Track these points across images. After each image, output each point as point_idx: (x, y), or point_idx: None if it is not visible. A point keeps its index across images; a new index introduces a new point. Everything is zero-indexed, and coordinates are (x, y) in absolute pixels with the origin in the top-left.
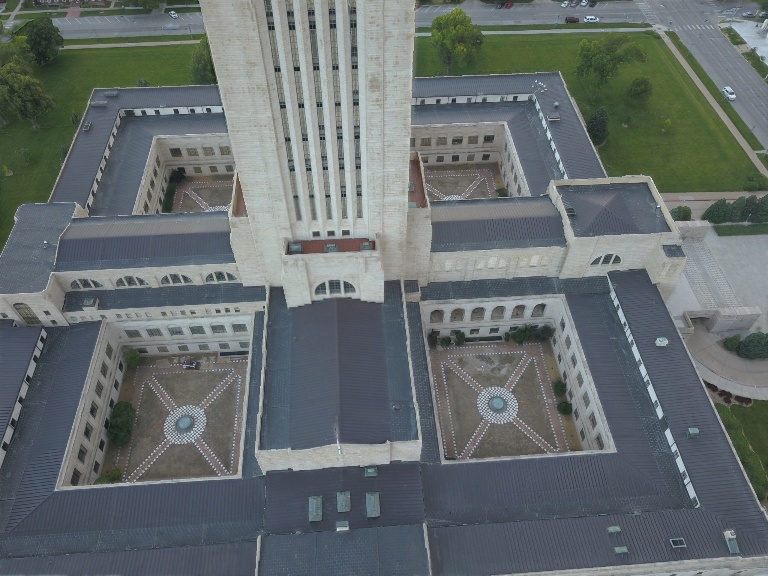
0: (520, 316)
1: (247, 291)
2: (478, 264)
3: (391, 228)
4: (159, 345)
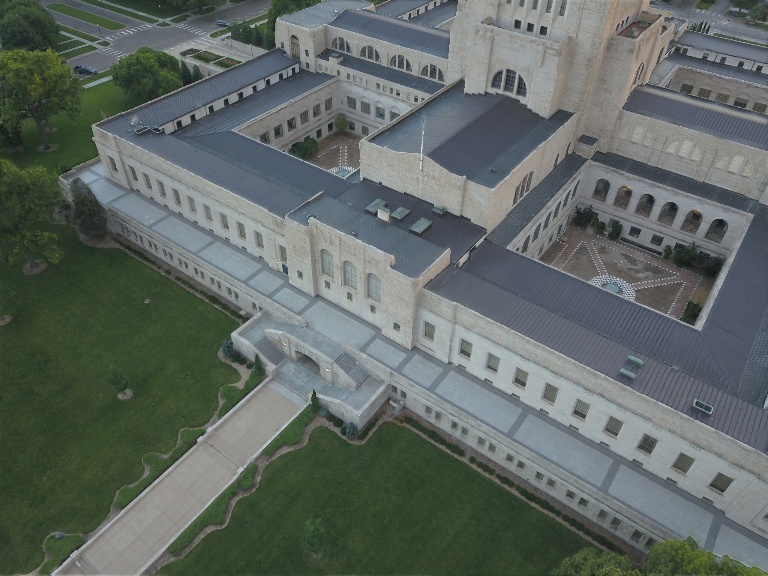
0: (692, 232)
1: None
2: (669, 146)
3: (585, 35)
4: (364, 124)
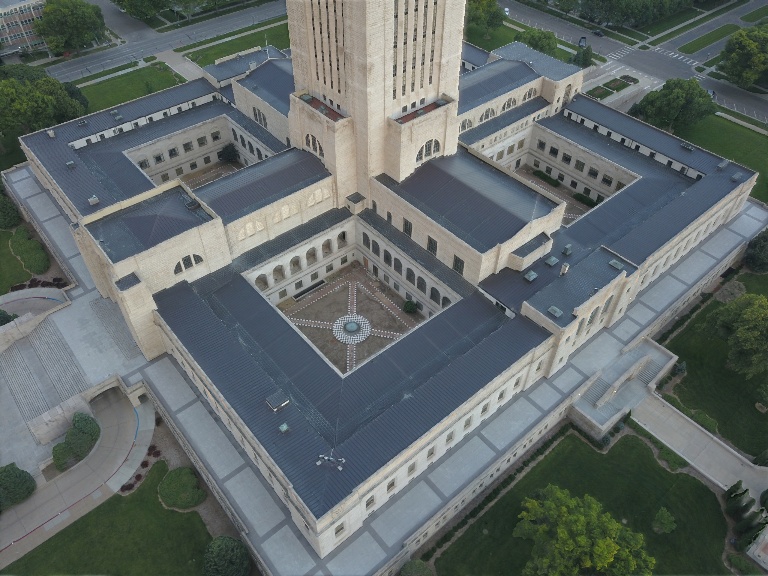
0: None
1: None
2: None
3: None
4: None
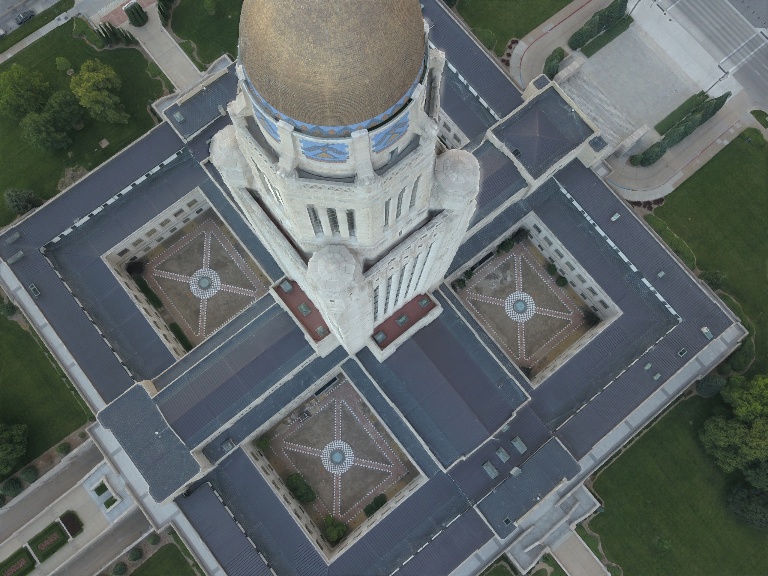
0: None
1: (327, 359)
2: (471, 232)
3: None
4: None
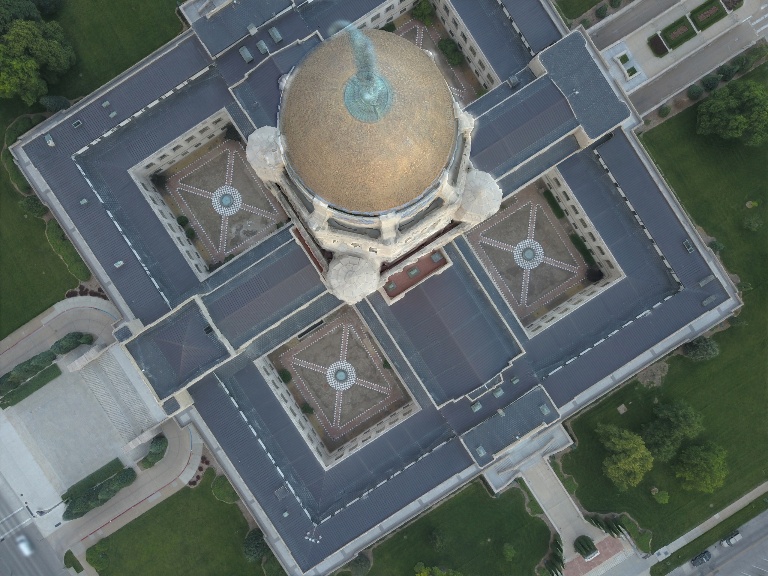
0: None
1: None
2: None
3: None
4: None
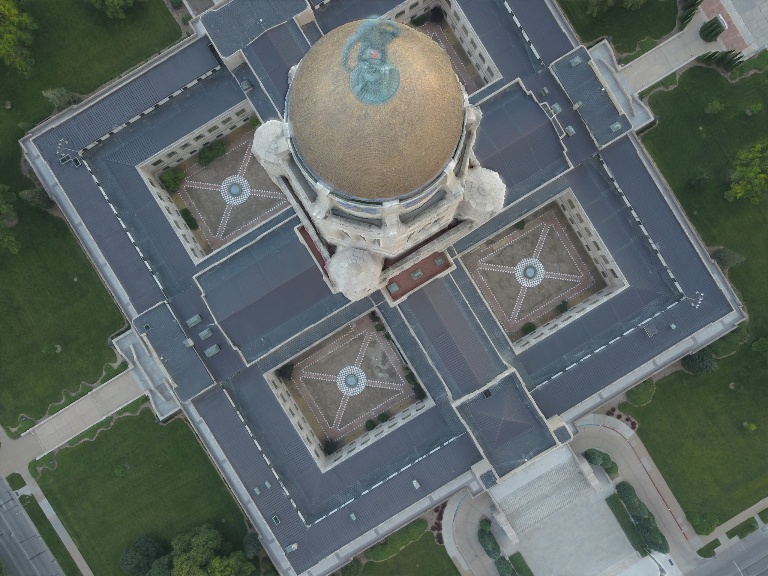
0: None
1: None
2: None
3: None
4: None
